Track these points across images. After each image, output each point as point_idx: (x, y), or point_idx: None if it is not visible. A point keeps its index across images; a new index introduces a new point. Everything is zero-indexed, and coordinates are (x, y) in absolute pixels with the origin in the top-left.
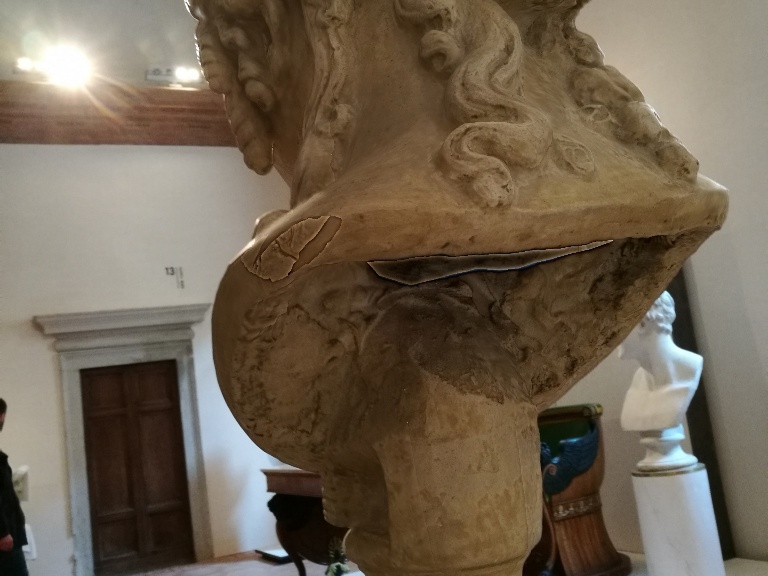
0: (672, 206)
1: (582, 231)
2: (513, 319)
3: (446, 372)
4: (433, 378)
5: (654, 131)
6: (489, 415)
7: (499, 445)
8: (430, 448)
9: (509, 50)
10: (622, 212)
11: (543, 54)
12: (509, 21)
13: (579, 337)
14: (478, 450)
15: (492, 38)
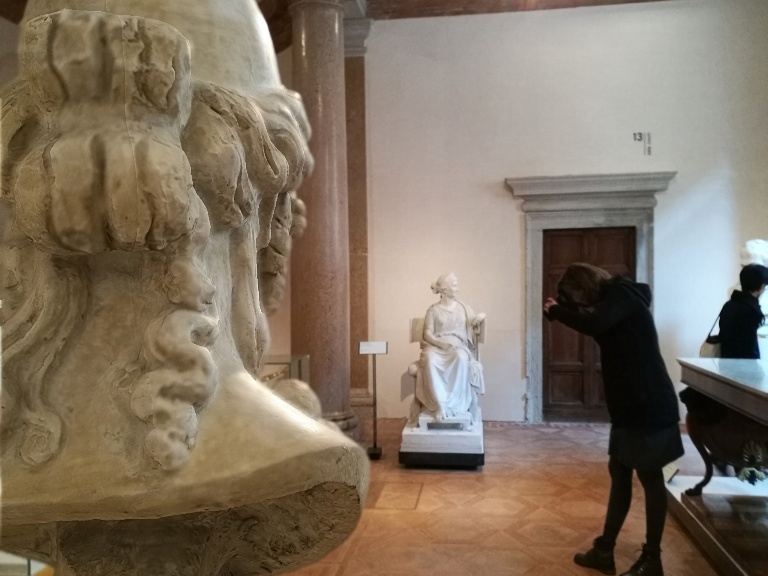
0: (124, 502)
1: (23, 518)
2: None
3: (77, 556)
4: (63, 560)
5: (143, 415)
6: None
7: None
8: None
9: (33, 322)
10: (57, 507)
11: (143, 290)
12: (48, 287)
13: (302, 519)
14: None
15: (24, 308)
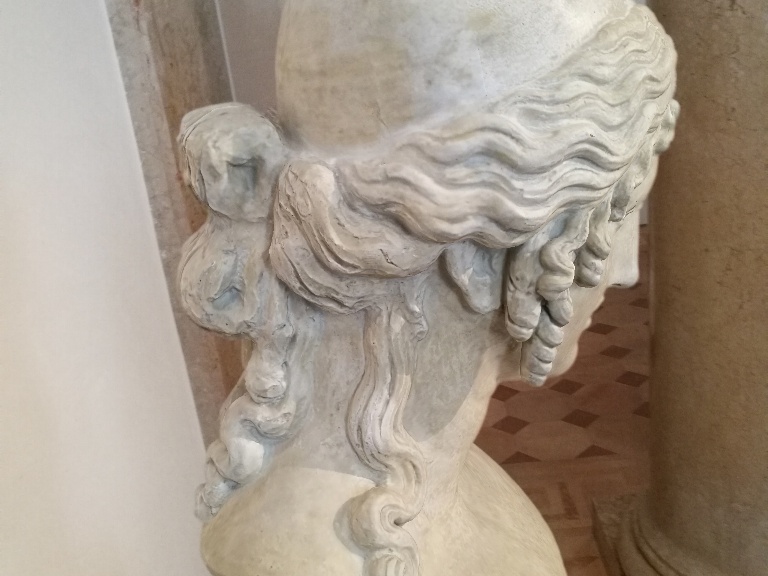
0: None
1: None
2: None
3: None
4: None
5: None
6: None
7: None
8: None
9: None
10: None
11: None
12: None
13: None
14: None
15: None
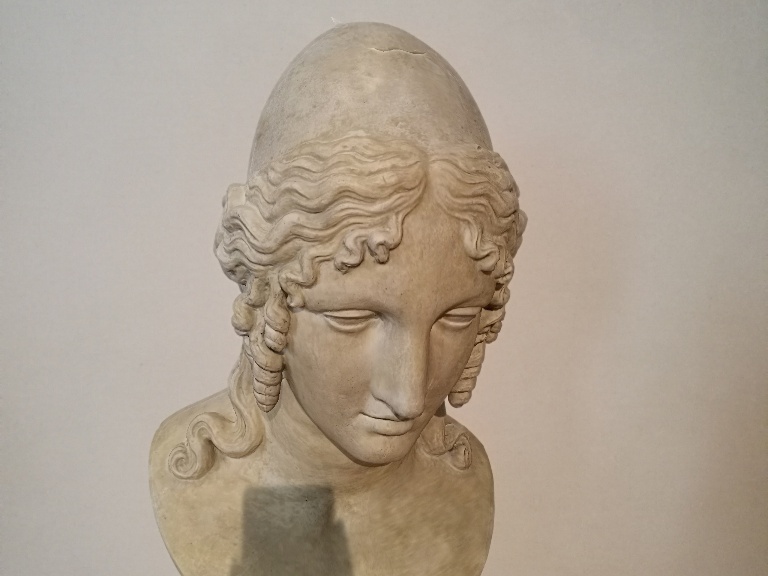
0: None
1: None
2: None
3: None
4: None
5: None
6: None
7: None
8: None
9: None
10: None
11: None
12: None
13: None
14: None
15: None
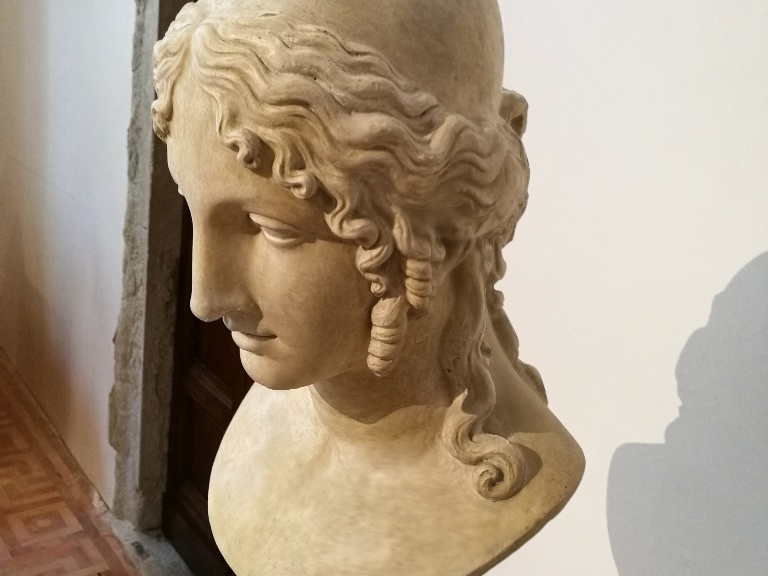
0: None
1: None
2: None
3: None
4: None
5: None
6: None
7: None
8: None
9: None
10: None
11: None
12: None
13: None
14: None
15: None
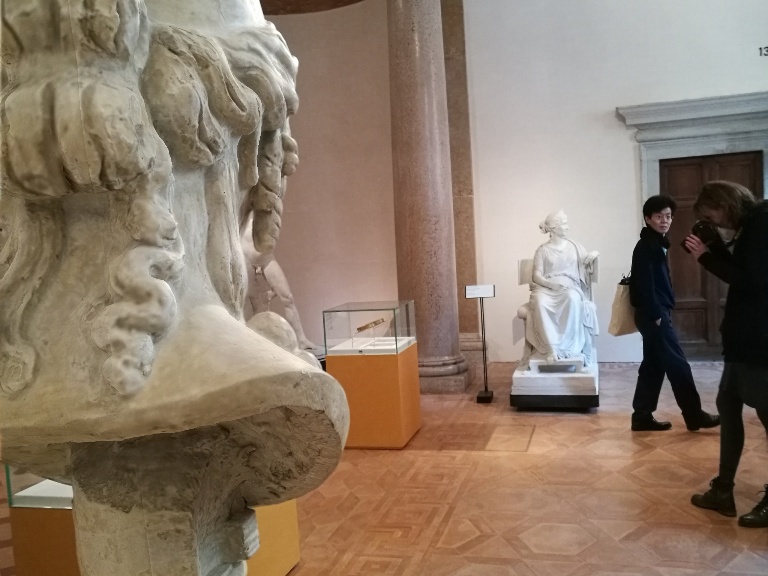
0: (88, 425)
1: (7, 441)
2: (223, 422)
3: (87, 480)
4: (75, 483)
5: (101, 344)
6: (113, 520)
7: (123, 544)
8: (79, 531)
9: (10, 263)
10: (32, 431)
11: (111, 229)
12: (22, 230)
13: (293, 445)
14: (104, 544)
15: (3, 251)
